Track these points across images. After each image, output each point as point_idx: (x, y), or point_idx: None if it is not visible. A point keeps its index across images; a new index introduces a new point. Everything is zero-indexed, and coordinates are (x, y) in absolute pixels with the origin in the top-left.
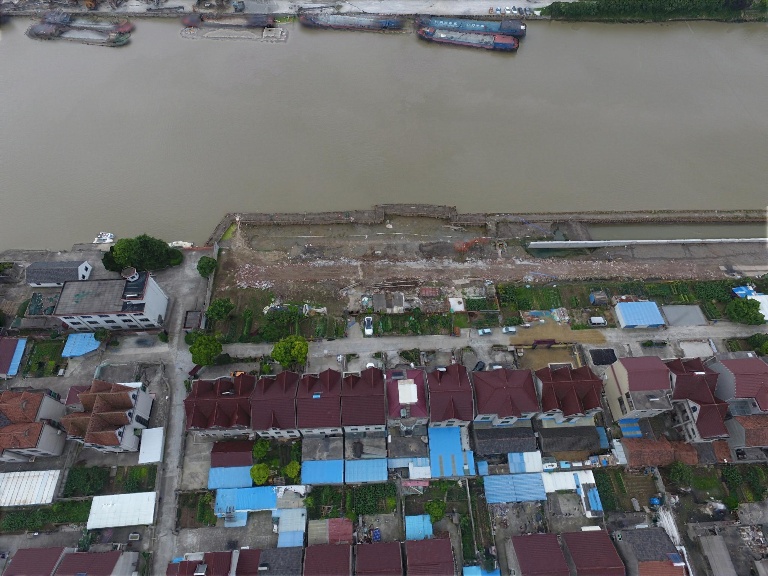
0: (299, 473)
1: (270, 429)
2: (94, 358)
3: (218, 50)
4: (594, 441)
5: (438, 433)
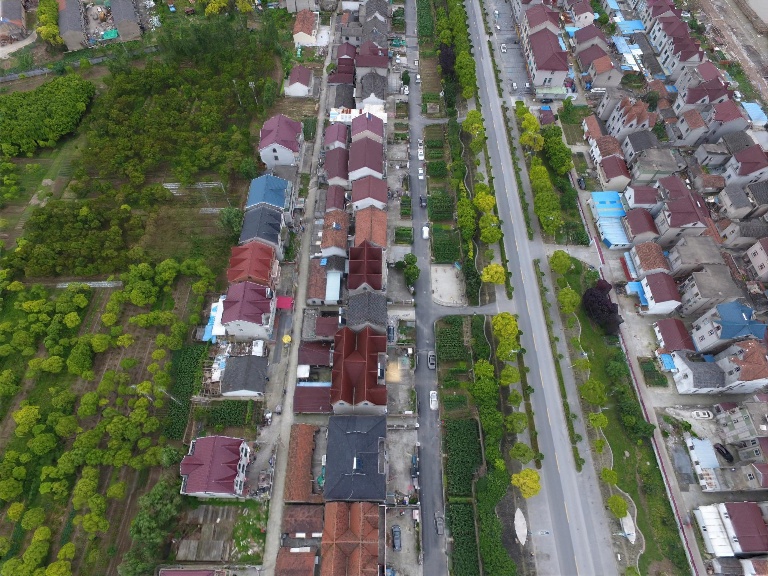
0: None
1: None
2: None
3: None
4: (657, 70)
5: (639, 23)
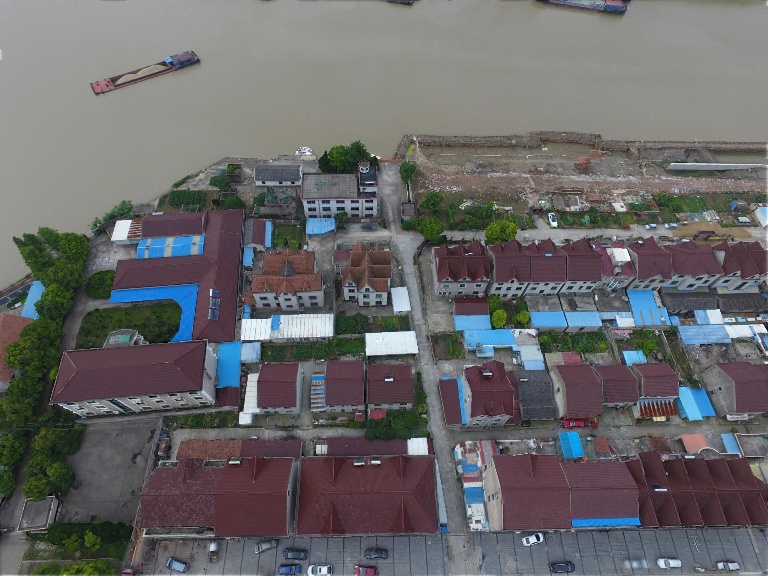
0: (530, 319)
1: (509, 282)
2: (328, 238)
3: (360, 4)
4: (763, 303)
5: (635, 294)
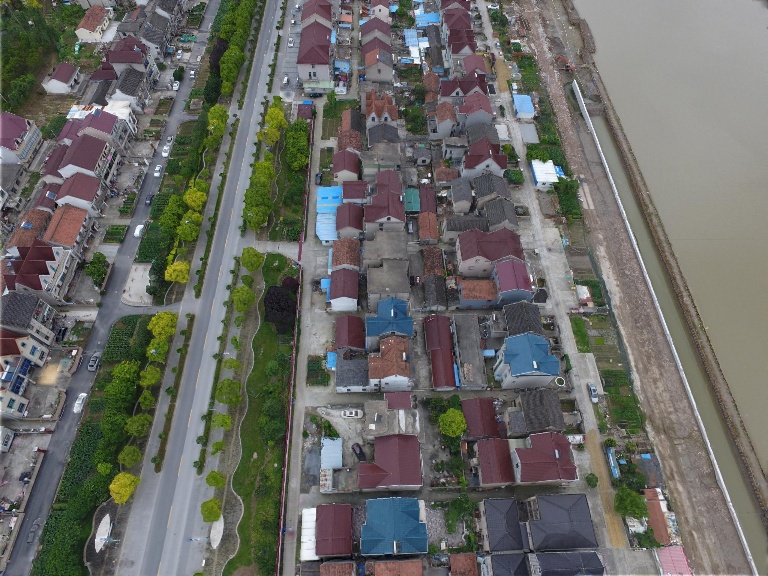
0: None
1: None
2: None
3: None
4: (436, 63)
5: (436, 15)
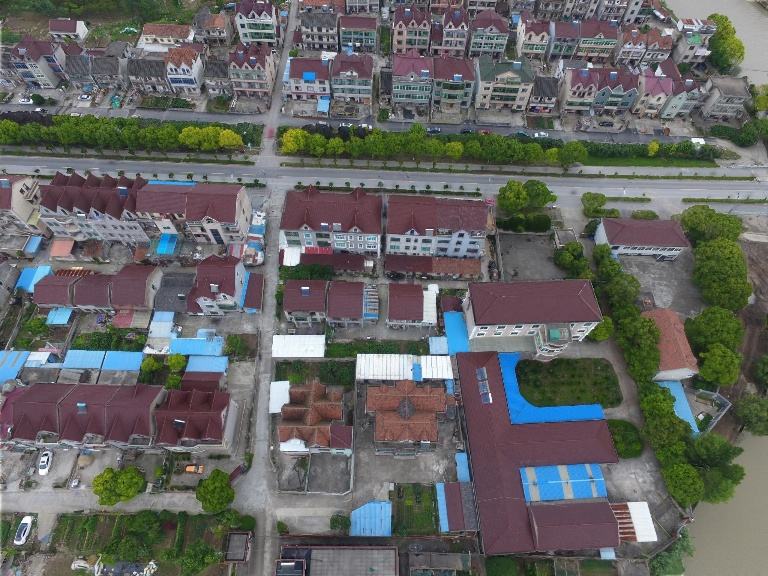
0: None
1: None
2: (361, 505)
3: None
4: None
5: None
